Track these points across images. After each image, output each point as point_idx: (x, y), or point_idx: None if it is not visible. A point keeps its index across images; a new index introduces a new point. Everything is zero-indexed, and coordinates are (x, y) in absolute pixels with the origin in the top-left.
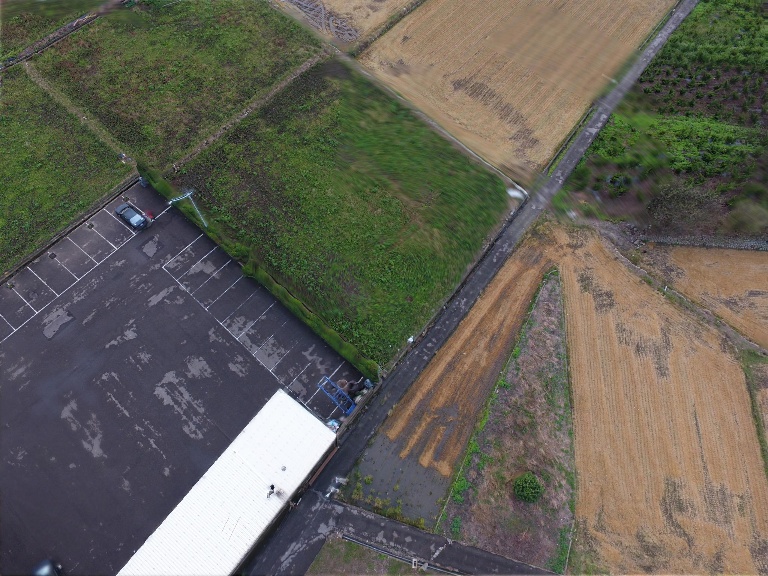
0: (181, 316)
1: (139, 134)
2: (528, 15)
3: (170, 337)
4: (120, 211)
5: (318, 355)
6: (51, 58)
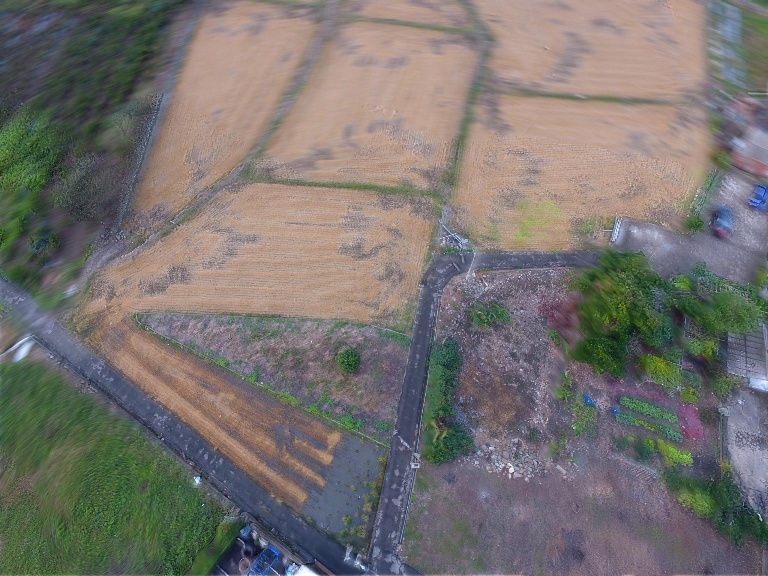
0: None
1: None
2: None
3: None
4: None
5: None
6: None
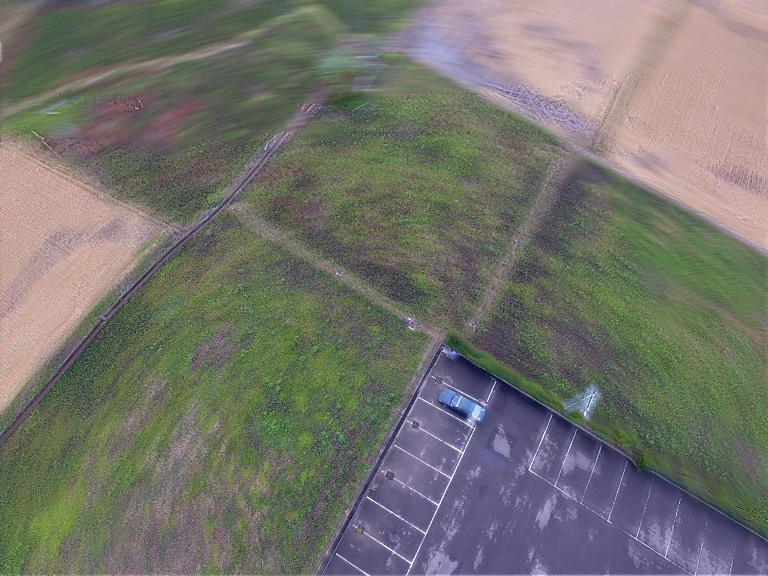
0: (585, 536)
1: (410, 287)
2: (744, 76)
3: (587, 570)
4: (450, 402)
5: (767, 563)
6: (257, 196)
